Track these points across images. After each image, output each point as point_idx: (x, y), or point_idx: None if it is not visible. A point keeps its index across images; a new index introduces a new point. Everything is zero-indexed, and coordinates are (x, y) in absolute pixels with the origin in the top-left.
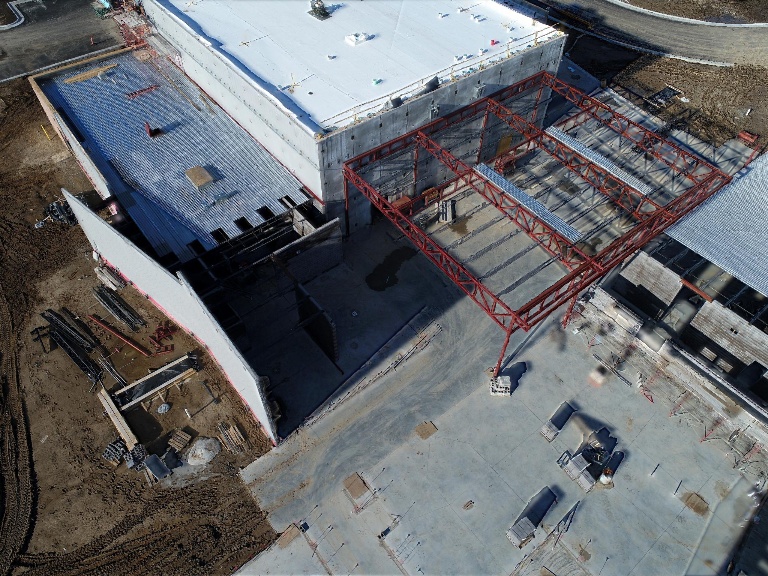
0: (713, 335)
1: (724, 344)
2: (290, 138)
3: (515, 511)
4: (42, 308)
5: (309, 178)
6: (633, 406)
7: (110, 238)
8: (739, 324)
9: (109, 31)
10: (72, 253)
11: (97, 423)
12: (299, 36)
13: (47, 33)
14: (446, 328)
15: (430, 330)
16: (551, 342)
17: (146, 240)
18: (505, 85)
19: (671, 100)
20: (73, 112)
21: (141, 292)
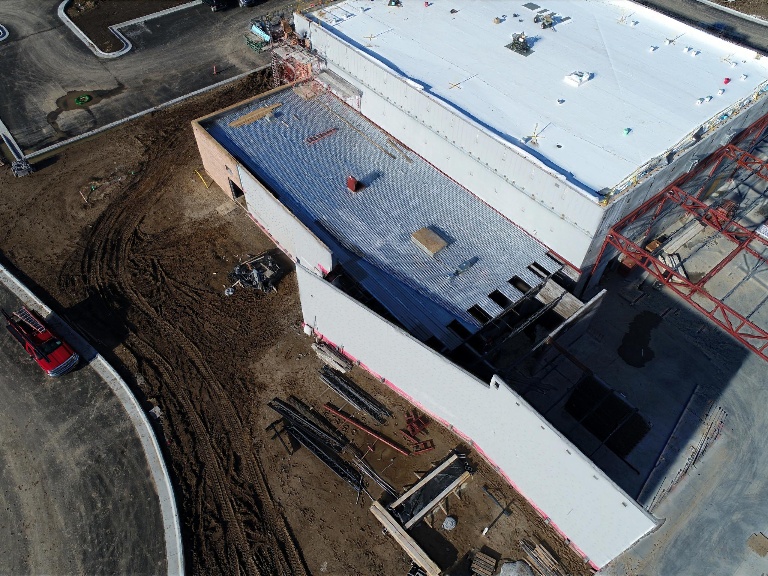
0: None
1: None
2: (547, 200)
3: None
4: (267, 397)
5: (563, 243)
6: None
7: (361, 321)
8: None
9: (227, 58)
10: (278, 326)
11: (379, 545)
12: (510, 75)
13: (161, 61)
14: (731, 412)
15: (714, 415)
16: None
17: (398, 321)
18: (743, 128)
19: None
20: (253, 162)
21: (373, 374)
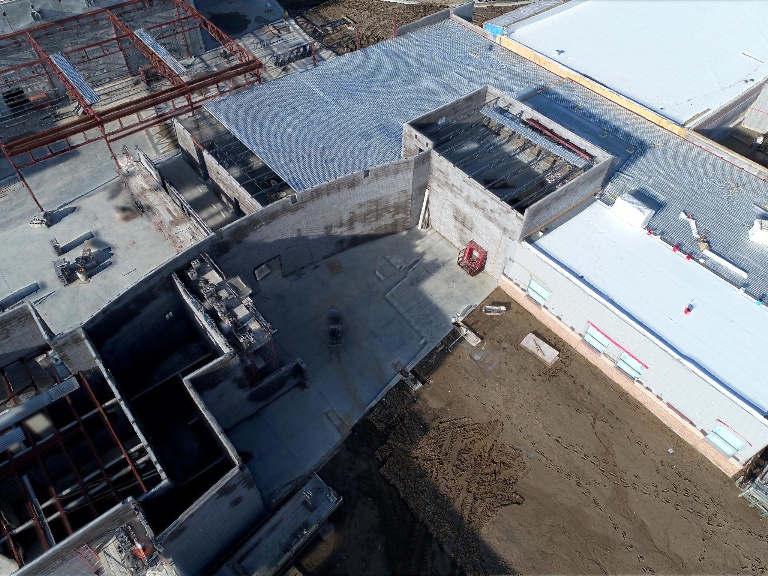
0: (217, 181)
1: (222, 187)
2: None
3: (0, 297)
4: None
5: None
6: (142, 234)
7: None
8: (216, 166)
9: None
10: None
11: None
12: None
13: None
14: None
15: (13, 187)
16: (106, 194)
17: None
18: None
19: (339, 28)
20: None
21: None
